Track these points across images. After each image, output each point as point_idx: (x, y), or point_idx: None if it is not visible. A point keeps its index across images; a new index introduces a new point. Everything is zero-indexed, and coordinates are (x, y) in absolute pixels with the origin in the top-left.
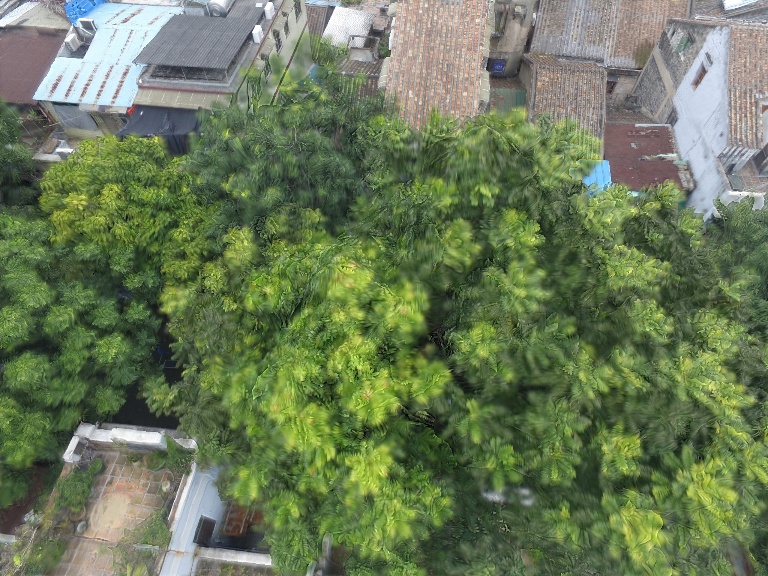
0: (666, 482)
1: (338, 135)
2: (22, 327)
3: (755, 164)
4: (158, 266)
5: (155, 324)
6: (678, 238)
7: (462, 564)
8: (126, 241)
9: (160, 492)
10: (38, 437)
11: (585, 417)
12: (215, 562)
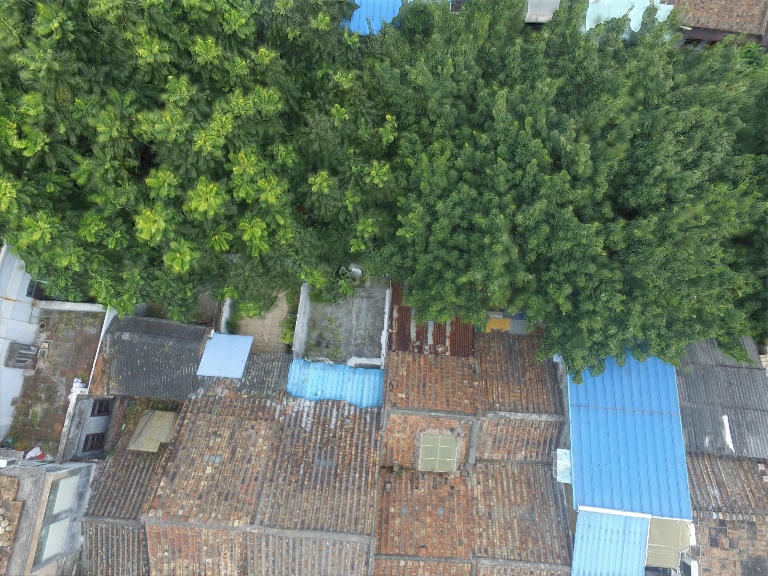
0: None
1: None
2: None
3: None
4: None
5: None
6: (318, 36)
7: None
8: None
9: None
10: None
11: None
12: (54, 312)
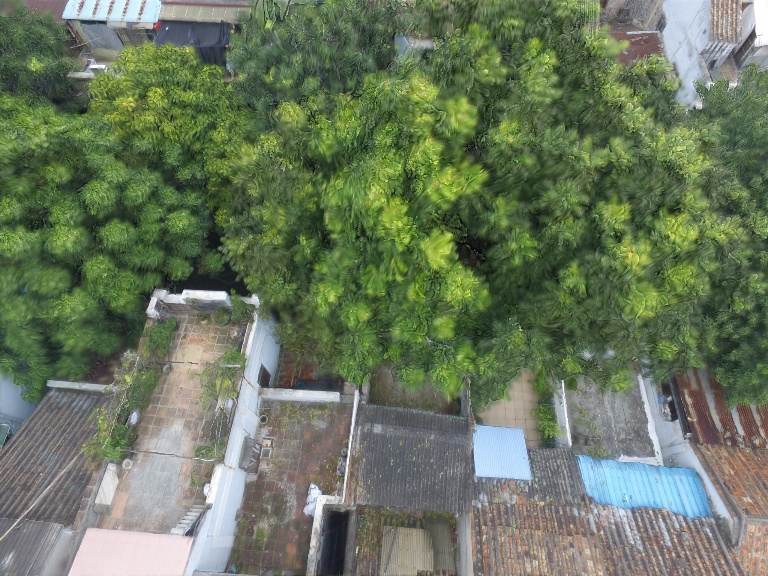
0: (642, 241)
1: (358, 36)
2: (107, 197)
3: (735, 61)
4: (200, 165)
5: (204, 214)
6: (659, 97)
7: (489, 336)
8: (172, 140)
9: (227, 342)
10: (127, 291)
11: (583, 206)
12: (275, 402)
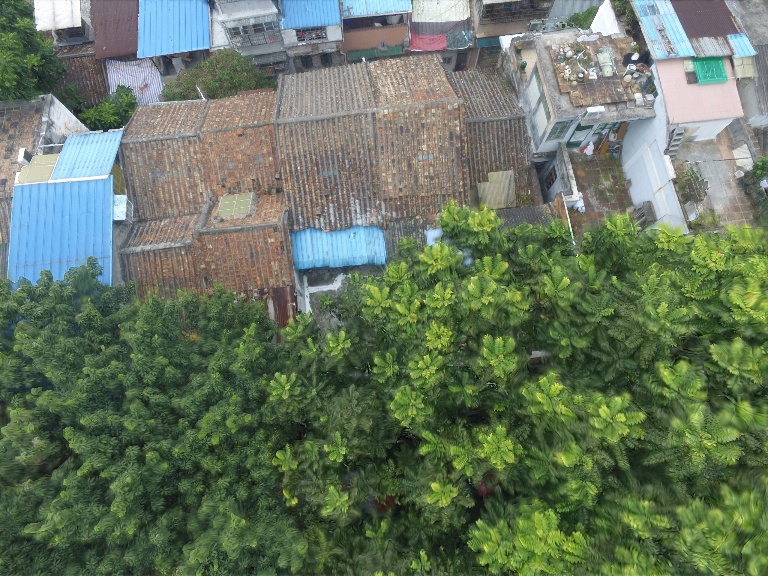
0: None
1: None
2: None
3: None
4: None
5: None
6: (386, 569)
7: None
8: None
9: None
10: None
11: None
12: None
